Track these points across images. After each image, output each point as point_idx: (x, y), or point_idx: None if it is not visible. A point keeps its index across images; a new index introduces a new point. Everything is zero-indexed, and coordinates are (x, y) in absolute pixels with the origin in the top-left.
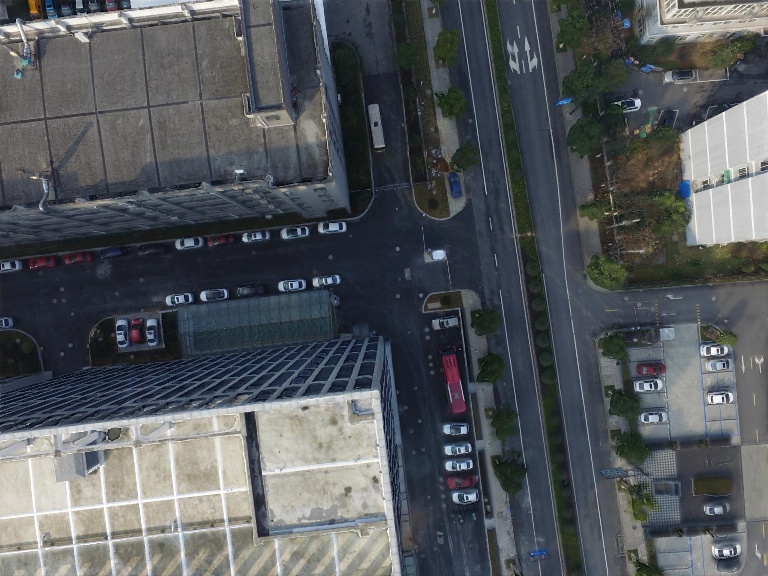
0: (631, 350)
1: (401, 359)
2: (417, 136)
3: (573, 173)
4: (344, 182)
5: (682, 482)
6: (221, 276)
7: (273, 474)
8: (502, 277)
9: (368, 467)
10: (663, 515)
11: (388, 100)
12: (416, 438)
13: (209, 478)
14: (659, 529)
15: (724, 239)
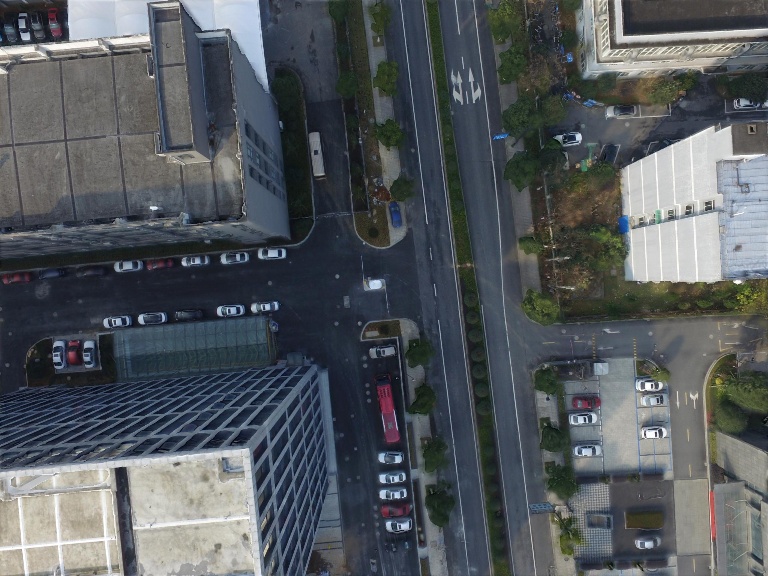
0: (567, 383)
1: (338, 387)
2: (357, 165)
3: (514, 205)
4: (280, 211)
5: (614, 515)
6: (160, 299)
7: (143, 529)
8: (441, 307)
9: (238, 524)
10: (595, 547)
11: (331, 128)
12: (351, 466)
13: (93, 525)
14: (590, 561)
15: (655, 278)
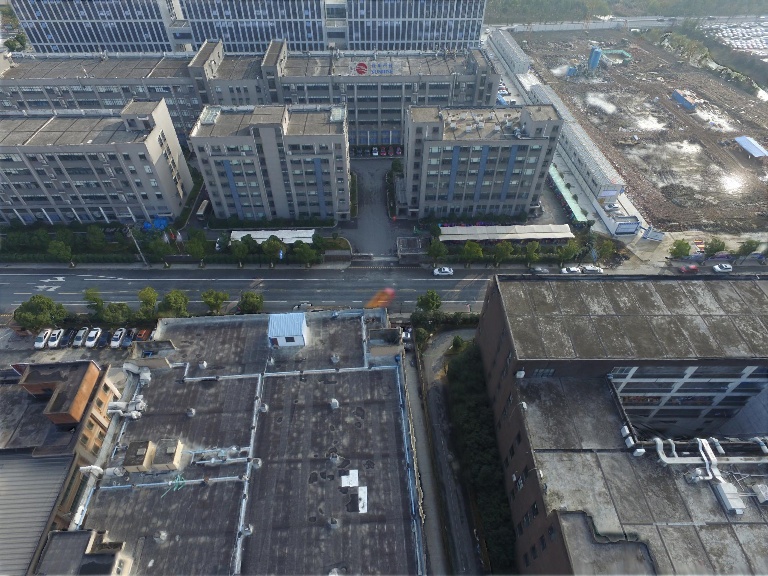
0: None
1: None
2: None
3: None
4: None
5: None
6: None
7: None
8: None
9: None
10: None
11: None
12: None
13: None
14: None
15: None
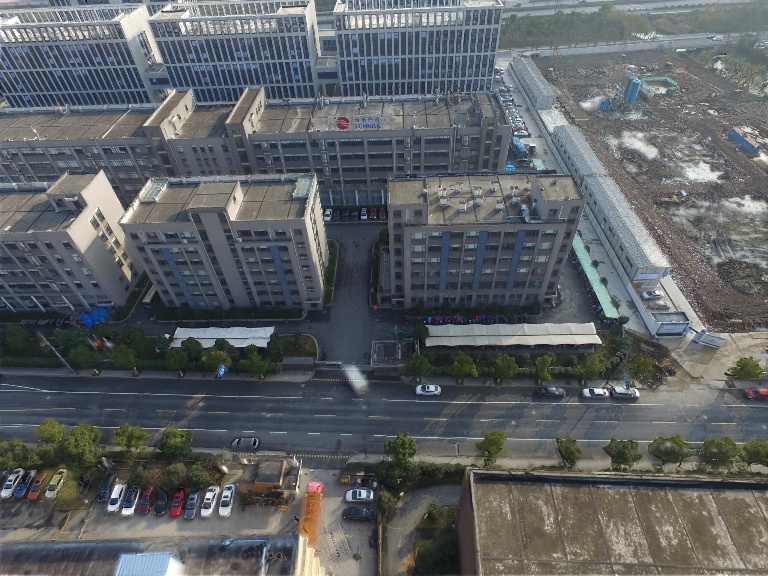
0: None
1: None
2: None
3: None
4: None
5: None
6: None
7: None
8: None
9: None
10: None
11: None
12: None
13: None
14: None
15: None
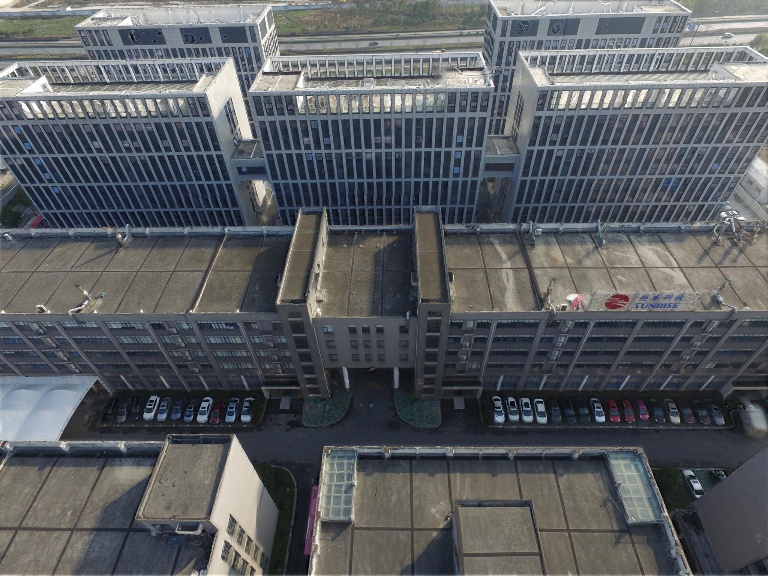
0: None
1: None
2: None
3: None
4: None
5: None
6: None
7: None
8: None
9: None
10: None
11: None
12: None
13: None
14: None
15: None
